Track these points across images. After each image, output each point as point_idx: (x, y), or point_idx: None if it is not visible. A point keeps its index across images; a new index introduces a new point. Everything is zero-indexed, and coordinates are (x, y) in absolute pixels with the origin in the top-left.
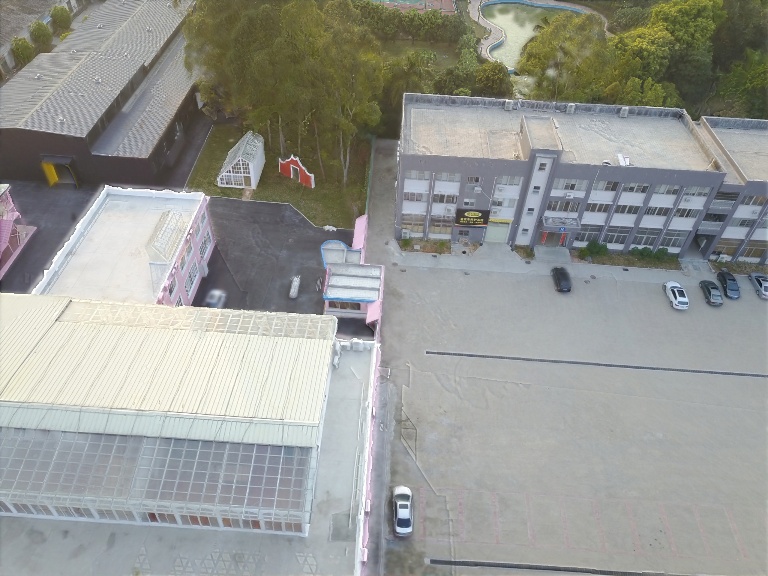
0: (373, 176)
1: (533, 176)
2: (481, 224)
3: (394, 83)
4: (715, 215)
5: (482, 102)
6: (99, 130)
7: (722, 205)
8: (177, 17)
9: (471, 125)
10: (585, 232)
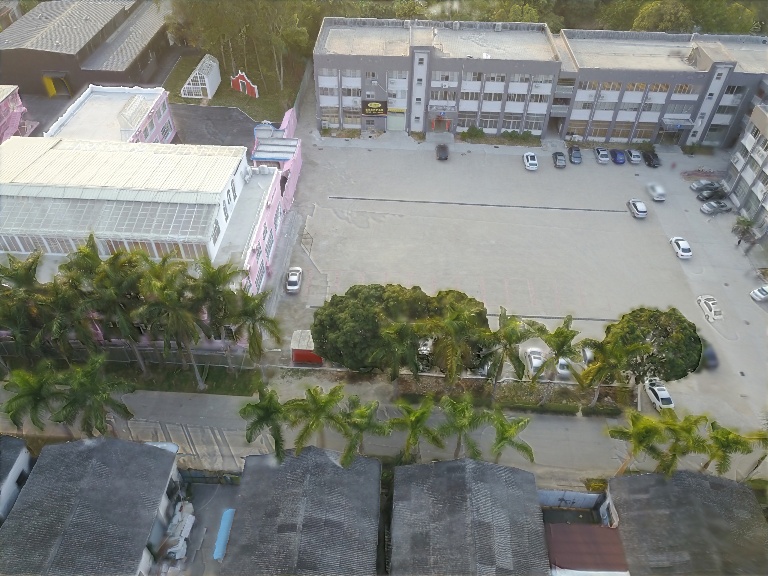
0: (307, 90)
1: (414, 69)
2: (382, 114)
3: (322, 14)
4: (561, 99)
5: (386, 23)
6: (87, 53)
7: (564, 90)
8: None
9: (374, 38)
10: (464, 119)
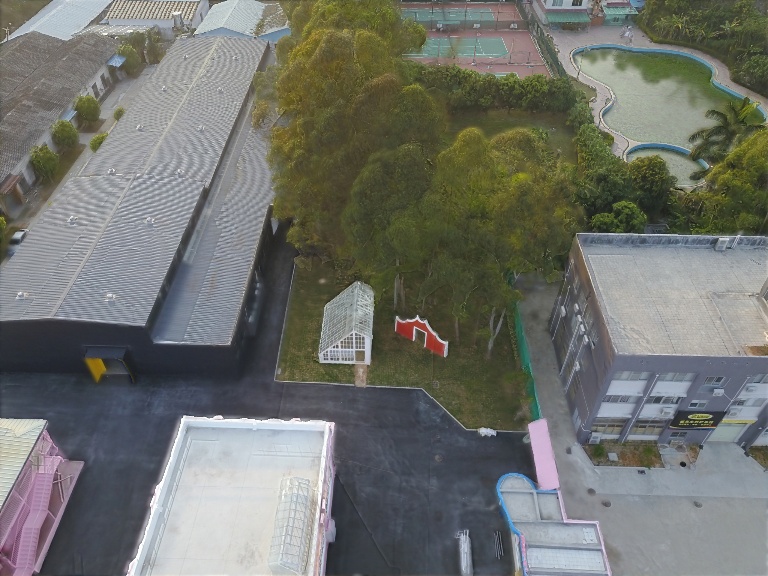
0: None
1: None
2: (708, 426)
3: None
4: None
5: (683, 240)
6: (159, 301)
7: None
8: (232, 107)
9: (682, 282)
10: None
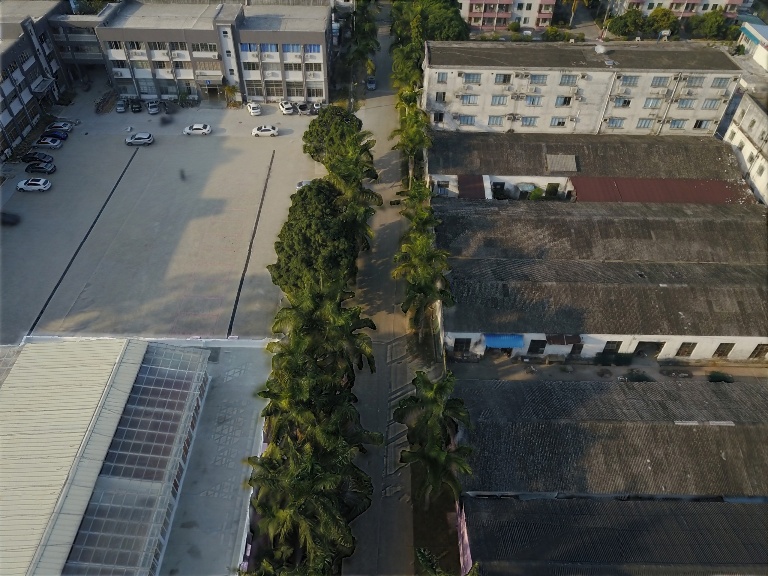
0: None
1: None
2: None
3: None
4: None
5: None
6: None
7: None
8: None
9: None
10: None
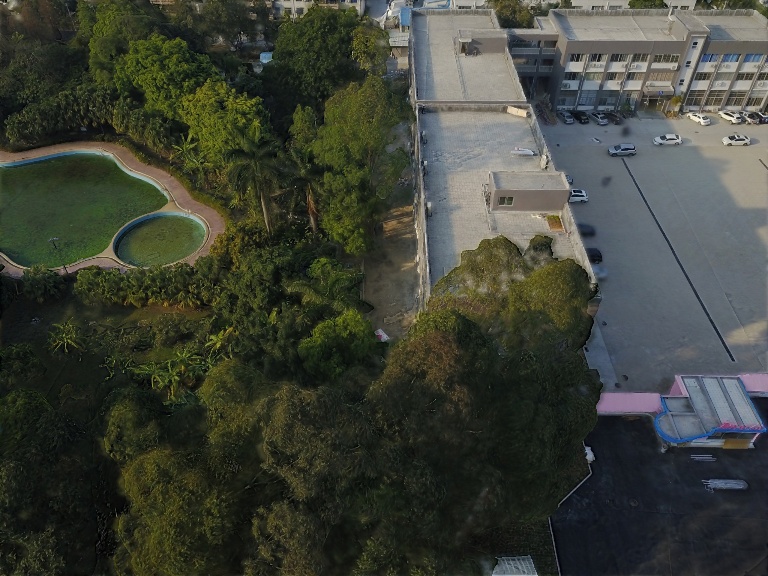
0: None
1: None
2: None
3: None
4: None
5: None
6: None
7: None
8: None
9: None
10: None
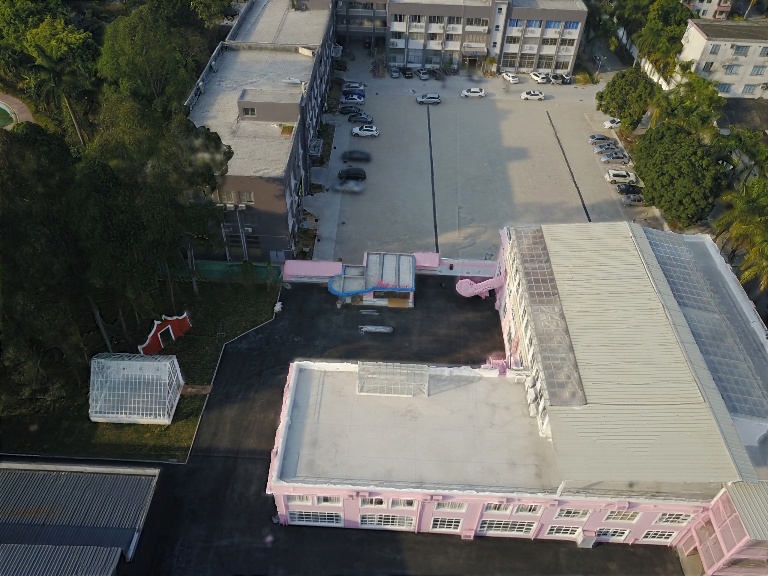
0: None
1: None
2: None
3: None
4: None
5: None
6: None
7: None
8: None
9: None
10: None
